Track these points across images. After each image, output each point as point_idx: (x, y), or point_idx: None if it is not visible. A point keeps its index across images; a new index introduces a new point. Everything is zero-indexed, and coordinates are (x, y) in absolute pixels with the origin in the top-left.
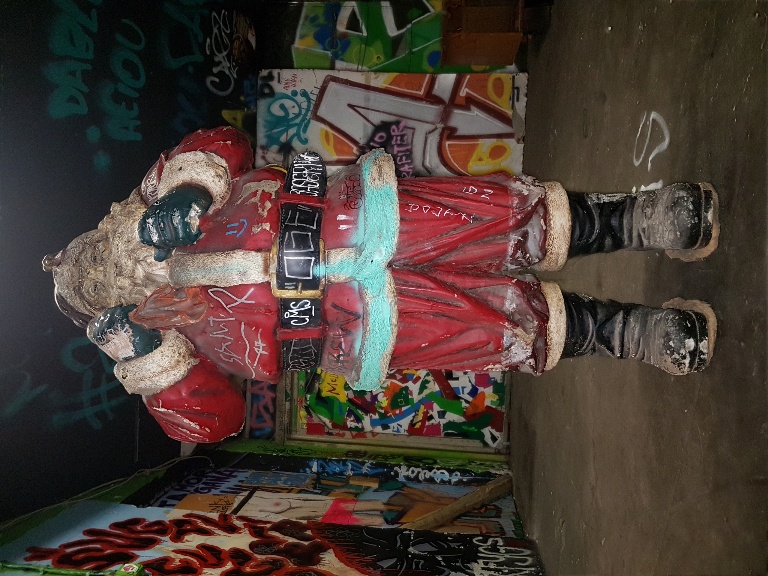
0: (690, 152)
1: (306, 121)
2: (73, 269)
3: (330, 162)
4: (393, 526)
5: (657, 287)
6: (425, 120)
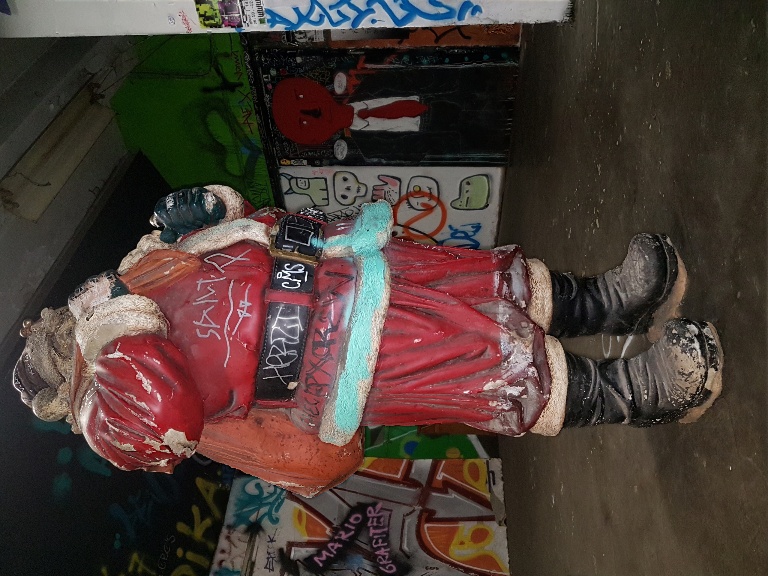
0: None
1: (280, 500)
2: None
3: (300, 543)
4: None
5: None
6: (402, 502)
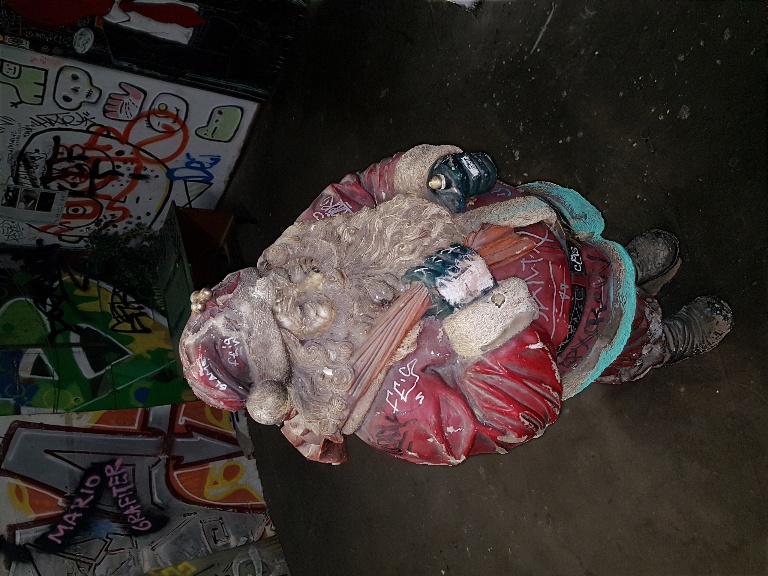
0: None
1: None
2: None
3: (24, 524)
4: None
5: None
6: (146, 453)
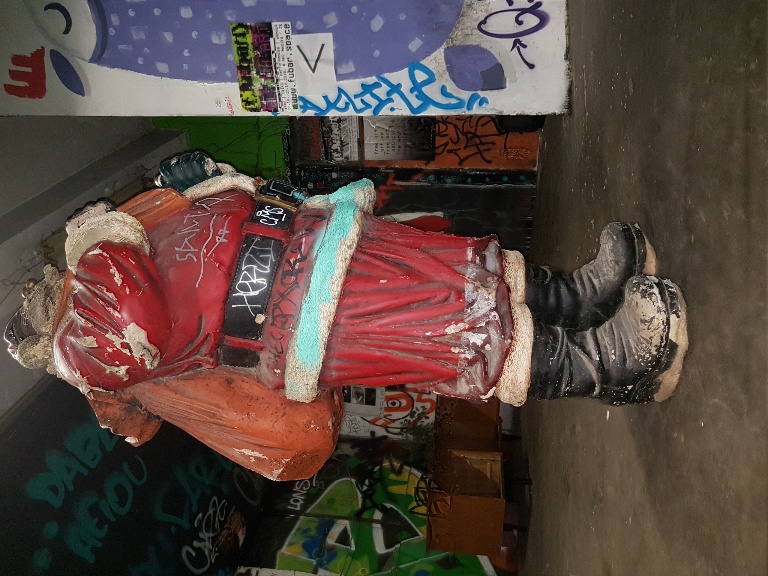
0: None
1: None
2: (58, 275)
3: None
4: None
5: (644, 417)
6: None
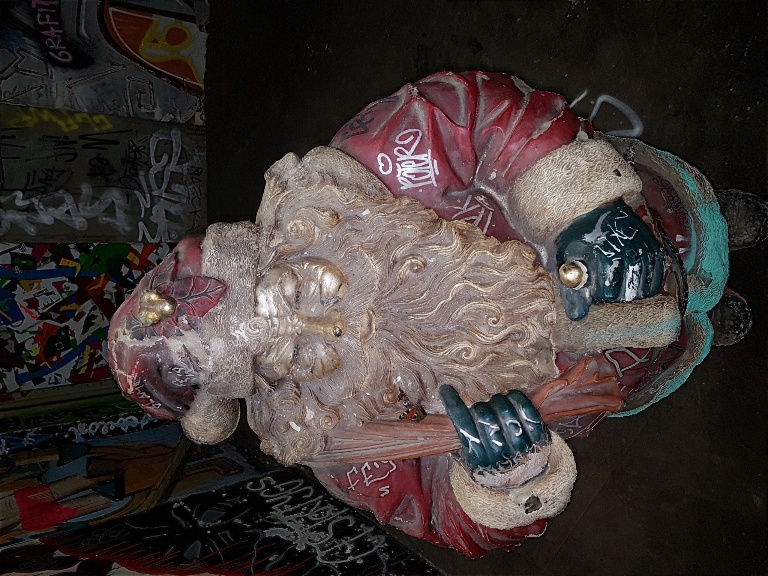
0: (686, 152)
1: None
2: None
3: None
4: (125, 501)
5: None
6: None
